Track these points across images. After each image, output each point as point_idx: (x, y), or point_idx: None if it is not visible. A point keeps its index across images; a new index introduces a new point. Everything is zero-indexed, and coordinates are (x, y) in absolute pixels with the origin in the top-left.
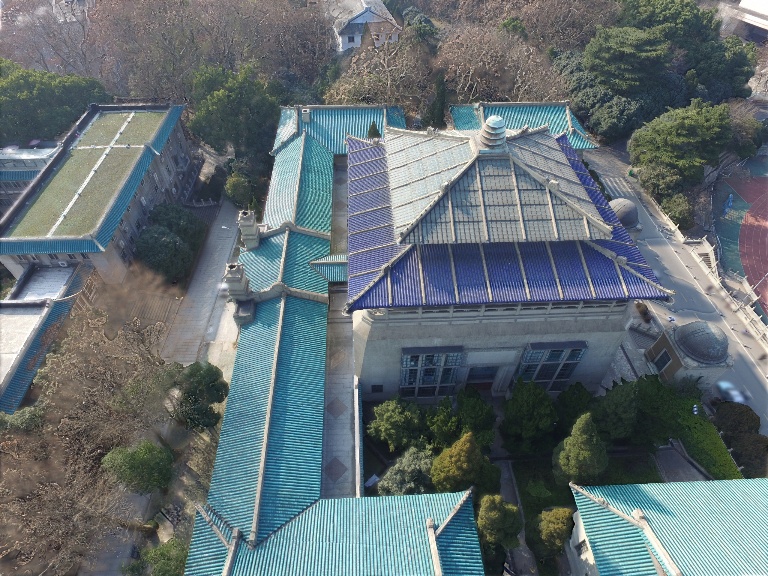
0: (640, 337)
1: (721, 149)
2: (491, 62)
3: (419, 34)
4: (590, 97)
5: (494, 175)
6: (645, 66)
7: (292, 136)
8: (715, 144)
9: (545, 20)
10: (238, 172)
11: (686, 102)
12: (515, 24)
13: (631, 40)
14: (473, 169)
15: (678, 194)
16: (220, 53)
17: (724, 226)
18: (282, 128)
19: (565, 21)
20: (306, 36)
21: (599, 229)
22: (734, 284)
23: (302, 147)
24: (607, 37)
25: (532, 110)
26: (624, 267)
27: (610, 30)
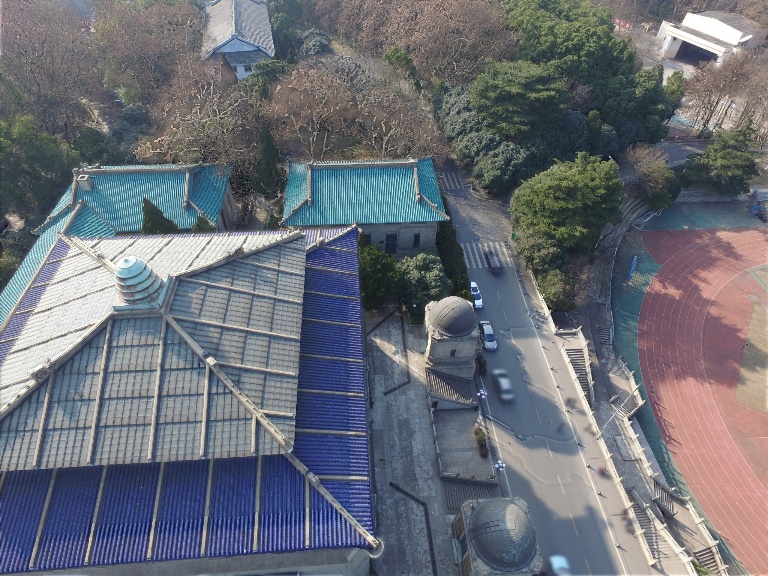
0: (459, 490)
1: (611, 212)
2: (363, 101)
3: (266, 72)
4: (475, 143)
5: (132, 345)
6: (538, 107)
7: (66, 209)
8: (602, 207)
9: (435, 51)
10: (11, 249)
11: (590, 146)
12: (399, 55)
13: (520, 78)
14: (102, 335)
15: (554, 271)
16: (34, 93)
17: (625, 295)
18: (66, 195)
19: (458, 52)
20: (167, 66)
21: (273, 436)
22: (619, 381)
23: (64, 227)
24: (496, 73)
25: (372, 173)
26: (318, 489)
27: (502, 64)
